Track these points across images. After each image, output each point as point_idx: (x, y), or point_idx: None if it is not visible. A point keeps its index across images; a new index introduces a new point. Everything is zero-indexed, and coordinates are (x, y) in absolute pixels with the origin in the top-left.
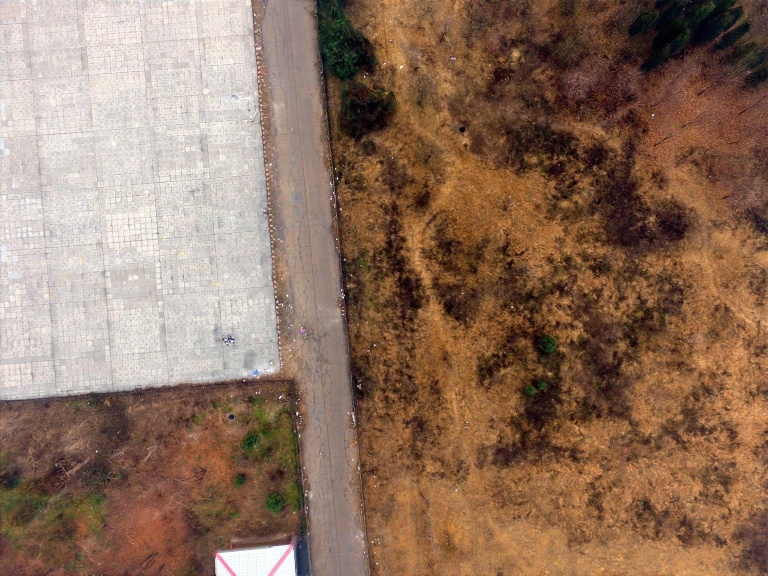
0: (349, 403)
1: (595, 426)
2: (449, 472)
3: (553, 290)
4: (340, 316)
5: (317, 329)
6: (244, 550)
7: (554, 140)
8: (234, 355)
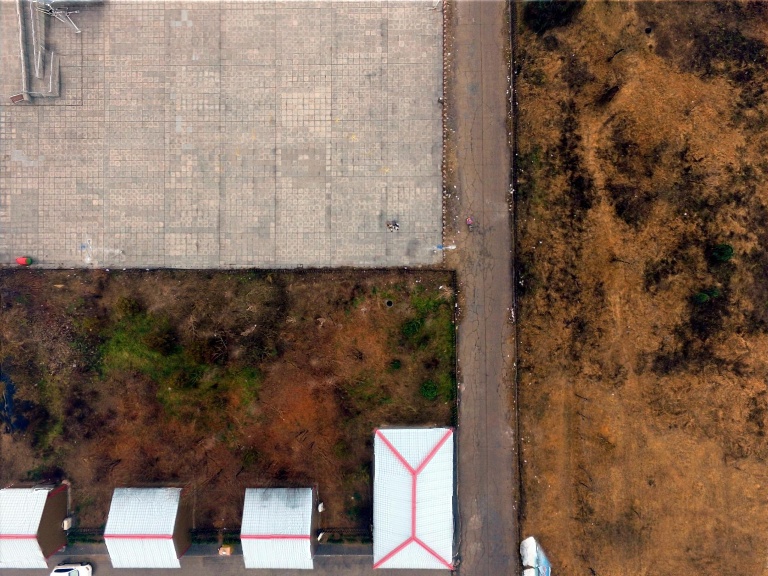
0: (509, 299)
1: (762, 341)
2: (607, 375)
3: (730, 200)
4: (507, 211)
5: (483, 222)
6: (405, 428)
7: (743, 47)
8: (397, 242)
